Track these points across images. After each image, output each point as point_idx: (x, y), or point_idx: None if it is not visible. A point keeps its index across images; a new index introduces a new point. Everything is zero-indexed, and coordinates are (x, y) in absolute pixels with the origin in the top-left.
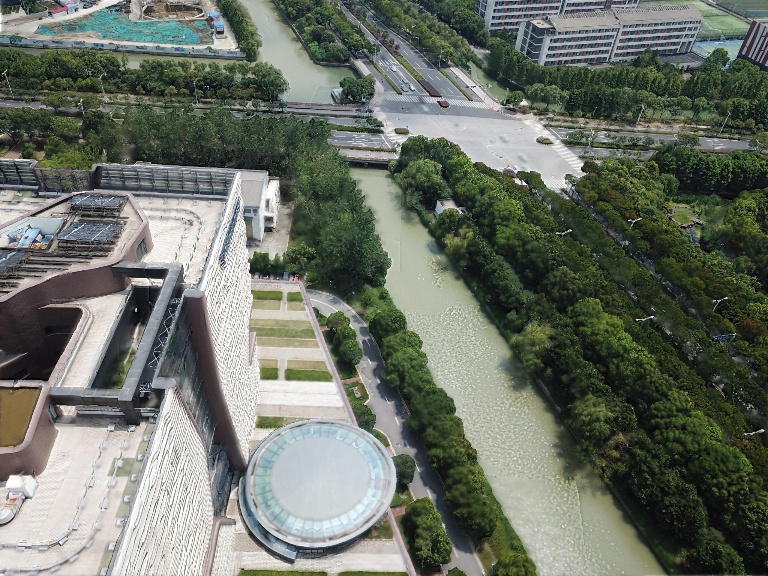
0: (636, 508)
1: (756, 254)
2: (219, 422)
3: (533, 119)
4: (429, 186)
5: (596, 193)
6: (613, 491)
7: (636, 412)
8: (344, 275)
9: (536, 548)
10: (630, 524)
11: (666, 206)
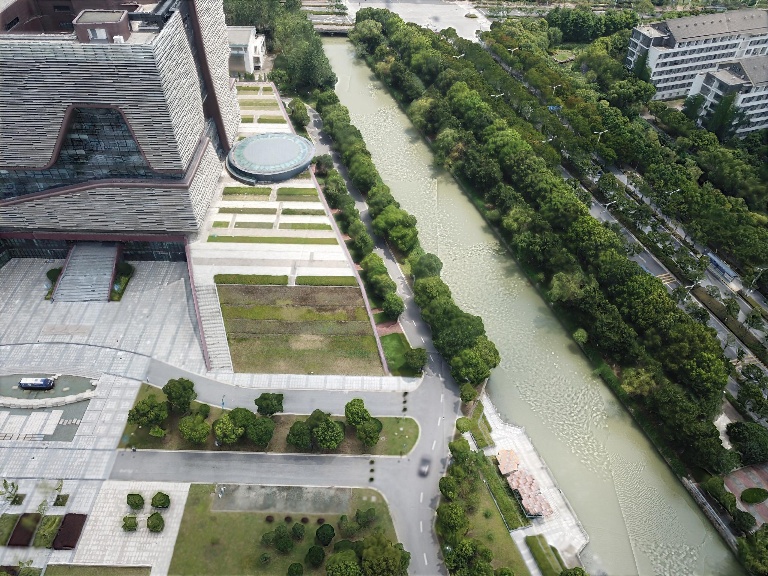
0: (468, 185)
1: (598, 68)
2: (209, 94)
3: (467, 4)
4: (371, 38)
5: (494, 39)
6: (458, 182)
7: (477, 138)
8: (305, 87)
9: (405, 207)
10: (465, 195)
11: (553, 52)
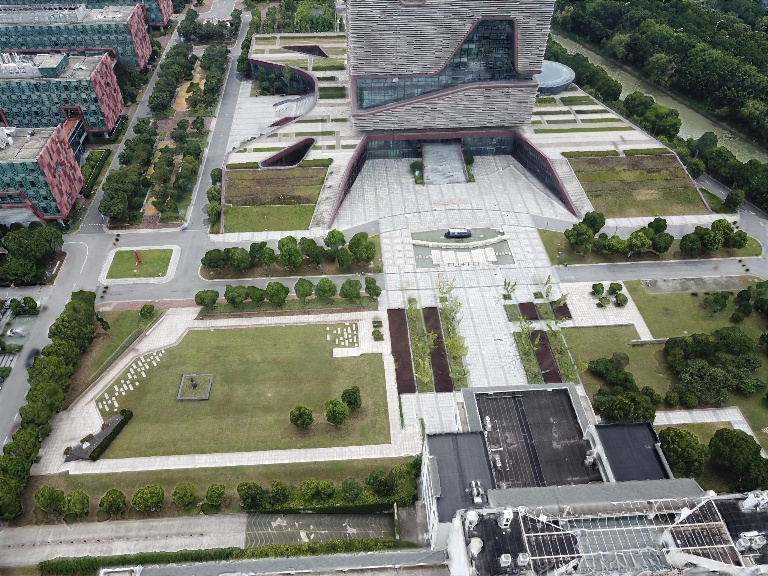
0: (684, 95)
1: (738, 9)
2: None
3: None
4: None
5: None
6: (671, 95)
7: None
8: None
9: None
10: (681, 104)
11: None
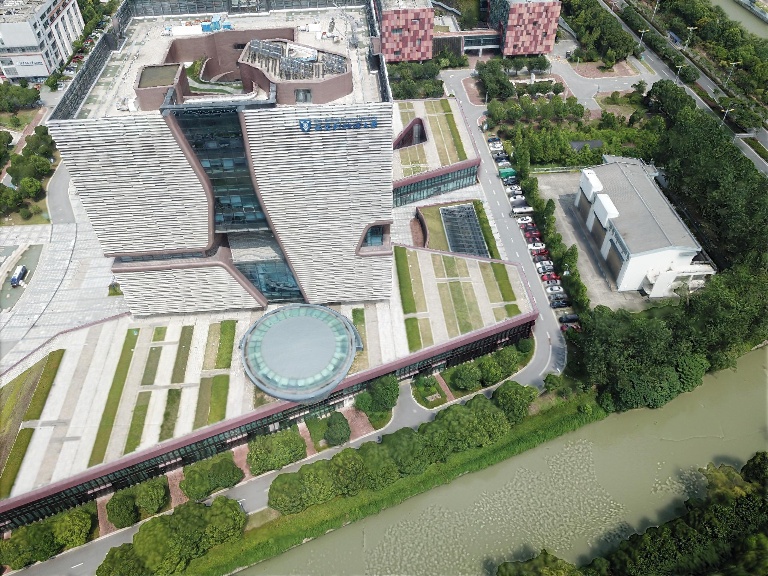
0: None
1: None
2: None
3: None
4: None
5: None
6: None
7: None
8: None
9: None
10: None
11: None
